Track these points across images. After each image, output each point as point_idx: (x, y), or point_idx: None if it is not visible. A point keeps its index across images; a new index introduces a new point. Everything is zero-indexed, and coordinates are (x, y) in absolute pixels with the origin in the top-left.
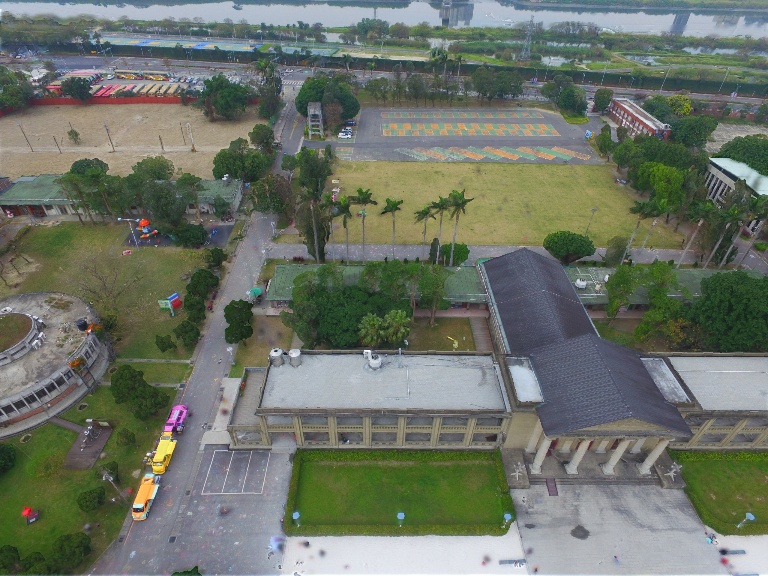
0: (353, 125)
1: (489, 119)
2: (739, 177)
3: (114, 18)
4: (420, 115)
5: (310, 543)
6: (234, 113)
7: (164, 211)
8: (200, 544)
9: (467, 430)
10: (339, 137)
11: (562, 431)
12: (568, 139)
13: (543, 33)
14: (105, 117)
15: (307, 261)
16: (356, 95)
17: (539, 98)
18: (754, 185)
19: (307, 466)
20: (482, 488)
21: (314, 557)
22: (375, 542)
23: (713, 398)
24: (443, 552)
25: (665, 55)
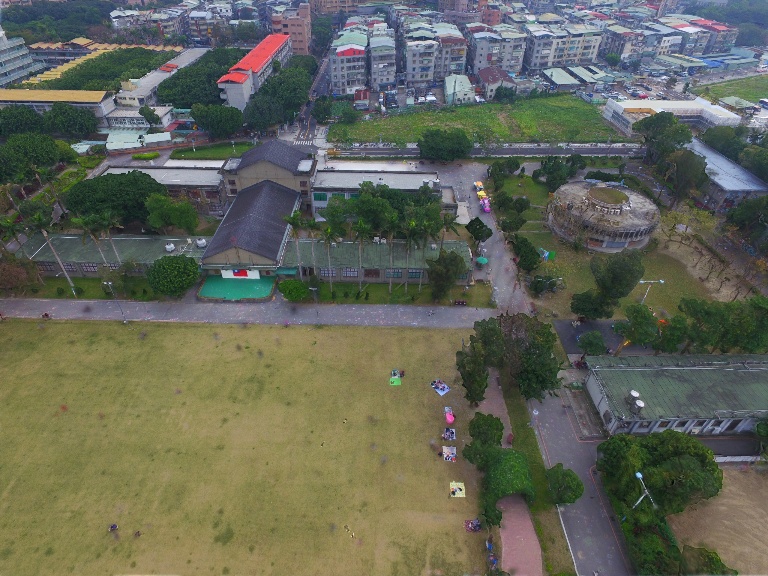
0: None
1: None
2: None
3: None
4: None
5: None
6: None
7: None
8: None
9: None
10: None
11: None
12: None
13: None
14: None
15: (451, 303)
16: None
17: None
18: None
19: None
20: None
21: None
22: None
23: None
24: None
25: None
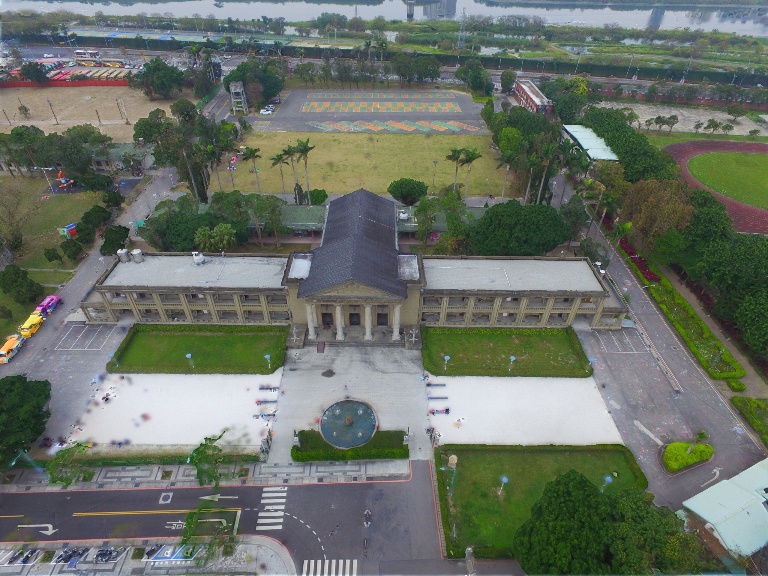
0: (278, 103)
1: (404, 99)
2: (577, 139)
3: (71, 10)
4: (342, 96)
5: (125, 377)
6: (170, 92)
7: (70, 160)
8: (44, 377)
9: (262, 308)
10: (261, 113)
11: (307, 294)
12: (467, 115)
13: (493, 26)
14: (58, 97)
15: None
16: (291, 79)
17: (456, 81)
18: (586, 144)
19: (140, 334)
20: (268, 348)
21: (125, 385)
22: (173, 378)
23: (451, 284)
24: (221, 383)
25: (599, 45)
